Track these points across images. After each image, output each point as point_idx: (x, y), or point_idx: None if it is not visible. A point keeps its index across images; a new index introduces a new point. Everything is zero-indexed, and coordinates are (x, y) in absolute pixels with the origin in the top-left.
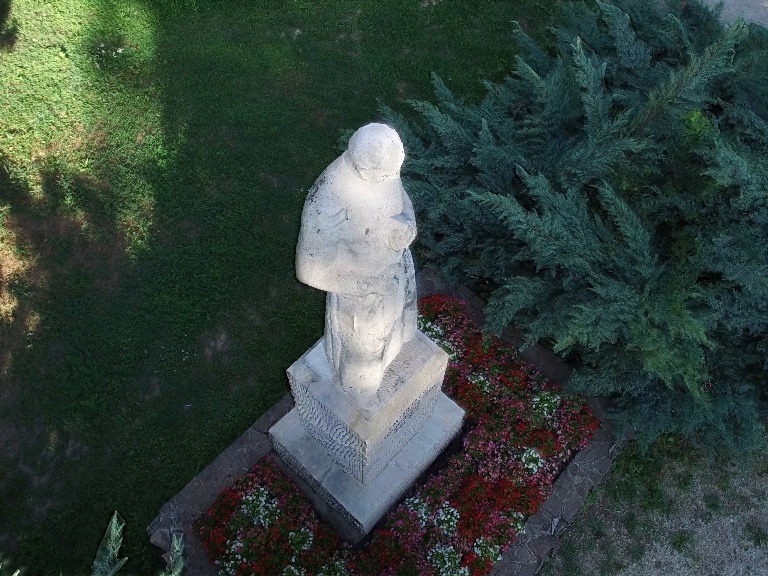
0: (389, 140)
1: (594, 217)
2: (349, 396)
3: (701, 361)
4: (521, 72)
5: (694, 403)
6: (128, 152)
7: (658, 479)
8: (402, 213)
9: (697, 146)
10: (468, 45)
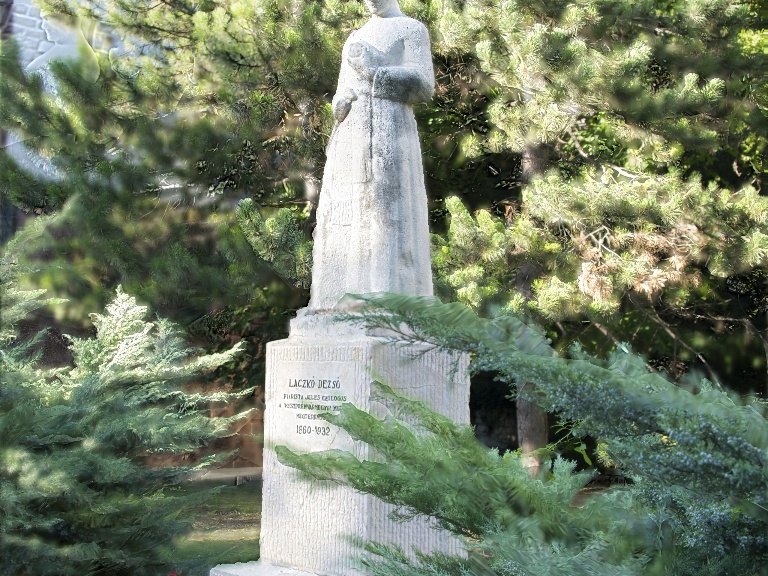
0: None
1: None
2: None
3: None
4: None
5: None
6: None
7: None
8: (381, 52)
9: None
10: None
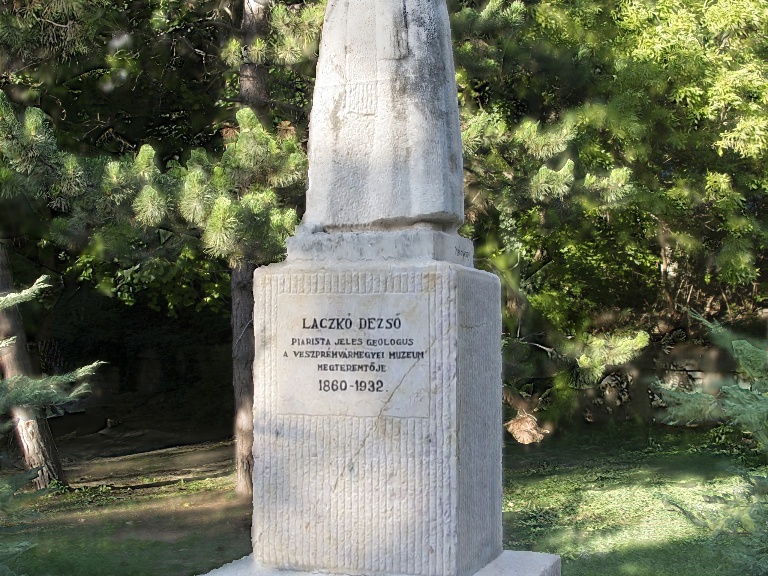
0: None
1: None
2: None
3: None
4: None
5: None
6: (655, 535)
7: None
8: None
9: None
10: None
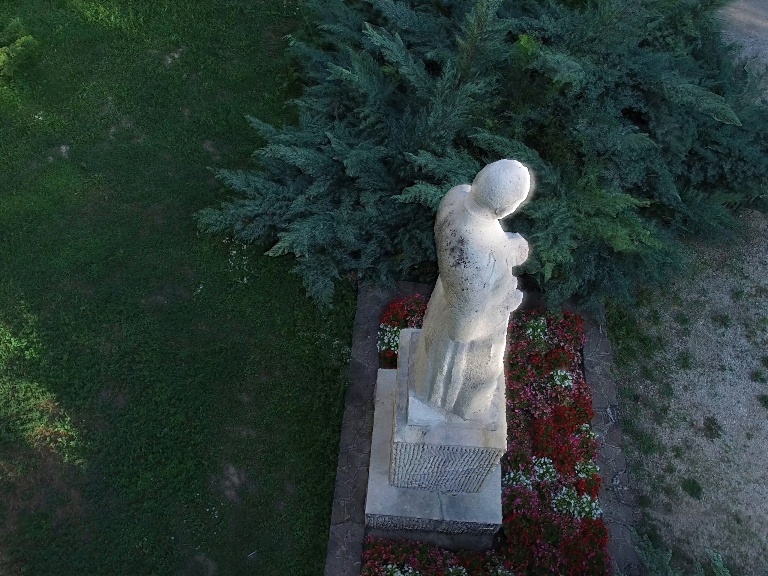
0: (523, 169)
1: (483, 161)
2: (470, 422)
3: (639, 220)
4: (334, 75)
5: (641, 256)
6: None
7: (640, 329)
8: None
9: (529, 62)
10: (237, 78)
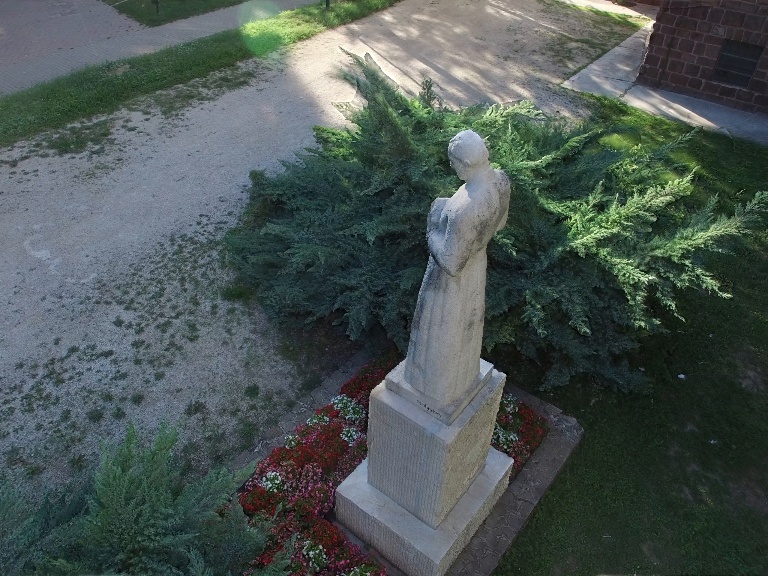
0: None
1: None
2: None
3: None
4: None
5: None
6: None
7: None
8: None
9: None
10: None
